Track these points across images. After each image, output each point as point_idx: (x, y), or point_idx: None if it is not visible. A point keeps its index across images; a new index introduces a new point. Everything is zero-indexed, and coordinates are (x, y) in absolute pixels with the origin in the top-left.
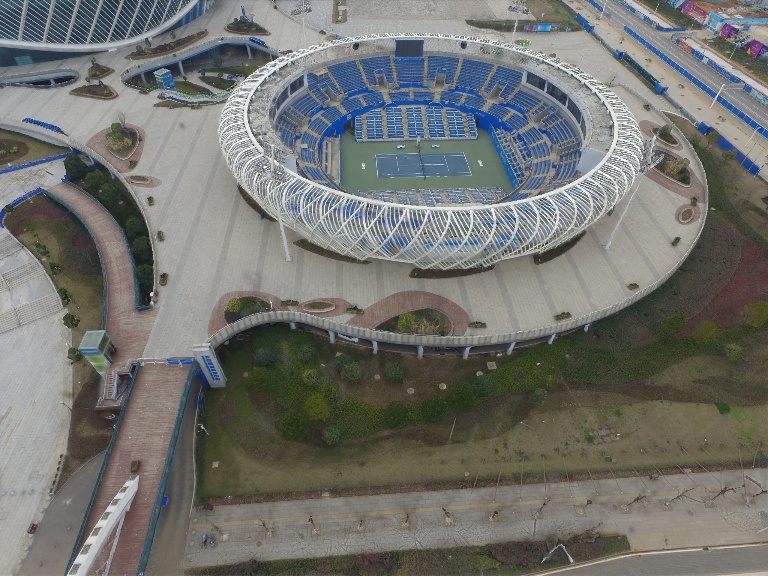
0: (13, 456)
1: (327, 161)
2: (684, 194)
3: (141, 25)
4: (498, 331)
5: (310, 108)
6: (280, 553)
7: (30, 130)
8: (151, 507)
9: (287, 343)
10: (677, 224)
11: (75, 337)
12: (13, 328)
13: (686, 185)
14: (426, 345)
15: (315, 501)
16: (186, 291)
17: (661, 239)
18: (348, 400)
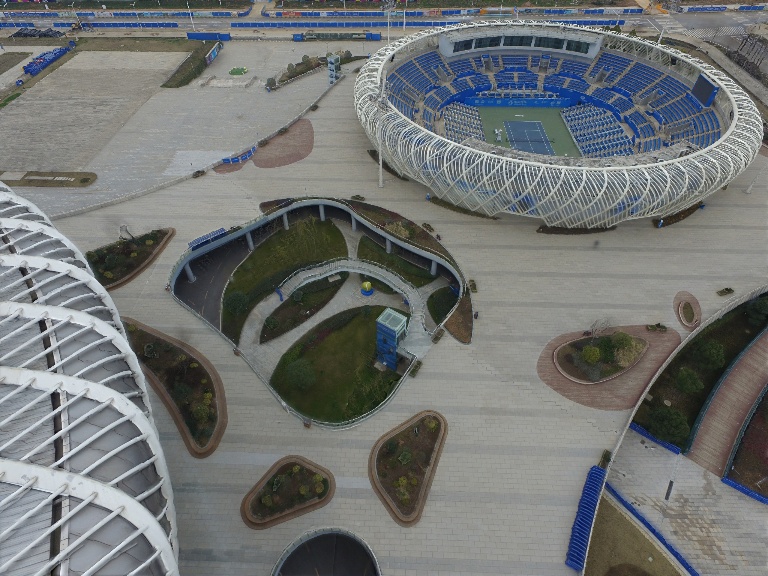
0: None
1: None
2: None
3: None
4: None
5: None
6: None
7: None
8: None
9: None
10: None
11: None
12: None
13: None
14: None
15: None
16: None
17: None
18: None
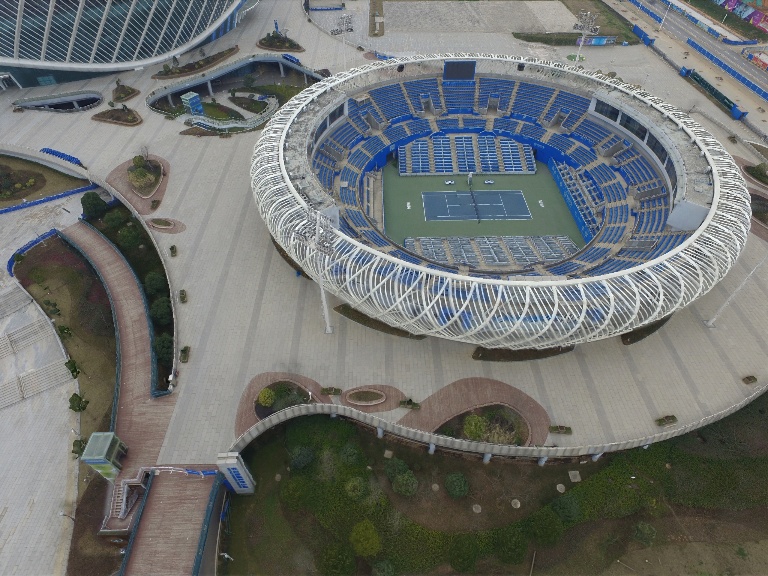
0: None
1: (369, 201)
2: None
3: (169, 42)
4: (587, 439)
5: (350, 139)
6: None
7: (48, 161)
8: None
9: (326, 436)
10: None
11: (84, 416)
12: (16, 402)
13: None
14: (497, 454)
15: None
16: (210, 371)
17: None
18: (401, 520)
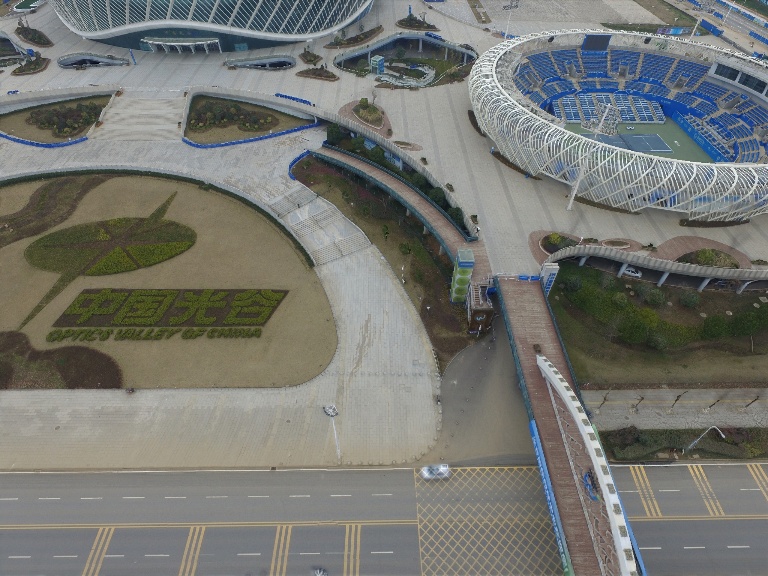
0: (392, 349)
1: None
2: None
3: (334, 19)
4: None
5: None
6: (647, 425)
7: (279, 104)
8: (565, 376)
9: (582, 275)
10: None
11: (393, 266)
12: (338, 257)
13: None
14: (718, 277)
15: (658, 391)
16: (497, 229)
17: None
18: None
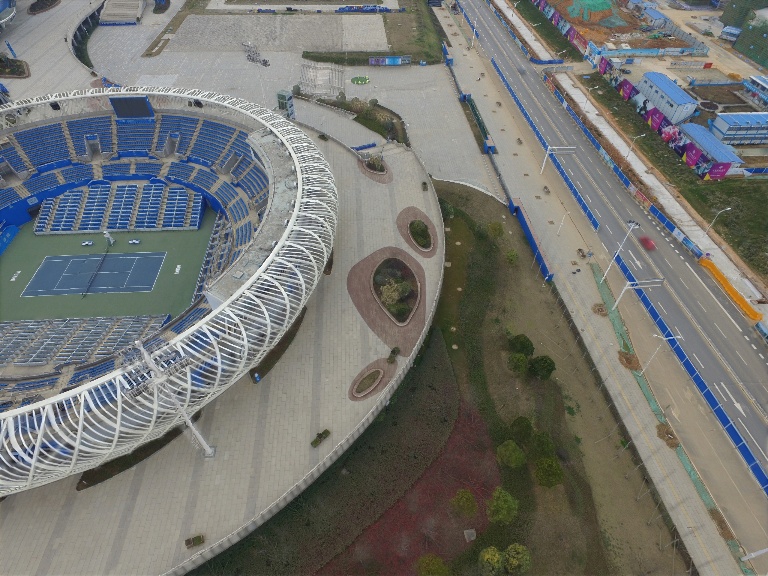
0: None
1: None
2: (389, 339)
3: None
4: None
5: None
6: None
7: None
8: None
9: None
10: (345, 400)
11: None
12: None
13: (399, 323)
14: None
15: None
16: None
17: (303, 432)
18: None
